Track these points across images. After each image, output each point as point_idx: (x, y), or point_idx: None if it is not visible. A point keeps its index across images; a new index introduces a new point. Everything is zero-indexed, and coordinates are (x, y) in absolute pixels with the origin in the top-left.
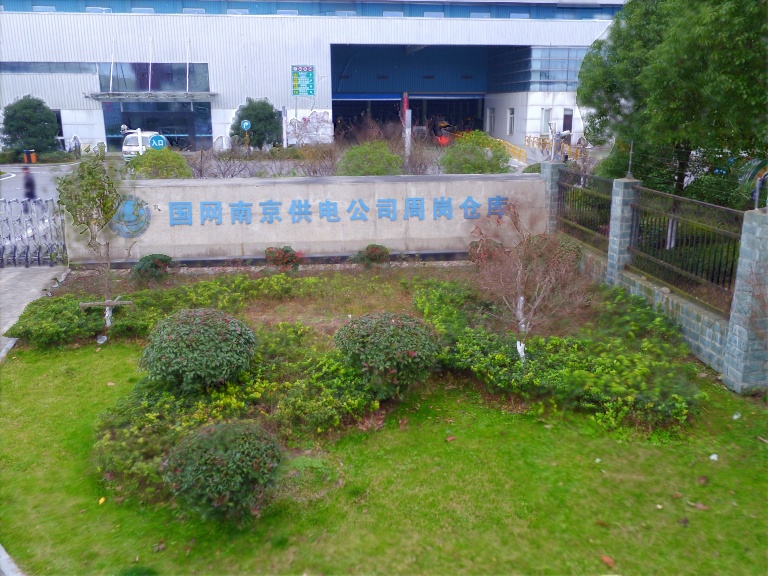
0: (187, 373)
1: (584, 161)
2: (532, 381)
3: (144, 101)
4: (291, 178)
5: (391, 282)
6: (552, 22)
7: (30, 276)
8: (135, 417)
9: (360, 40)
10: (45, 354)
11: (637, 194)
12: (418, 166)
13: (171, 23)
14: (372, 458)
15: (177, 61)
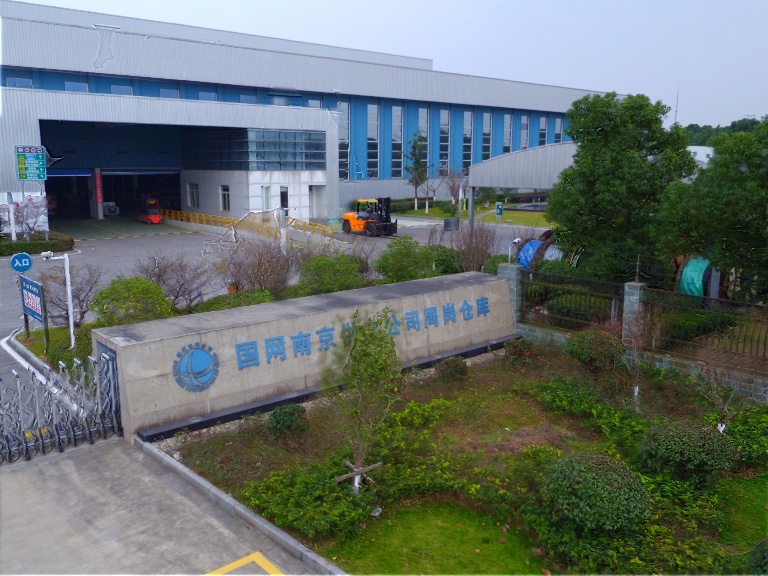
0: (644, 514)
1: None
2: (764, 451)
3: None
4: (305, 299)
5: None
6: (263, 107)
7: (97, 462)
8: (631, 567)
9: (74, 116)
10: (356, 544)
11: (650, 294)
12: None
13: None
14: (763, 538)
15: None
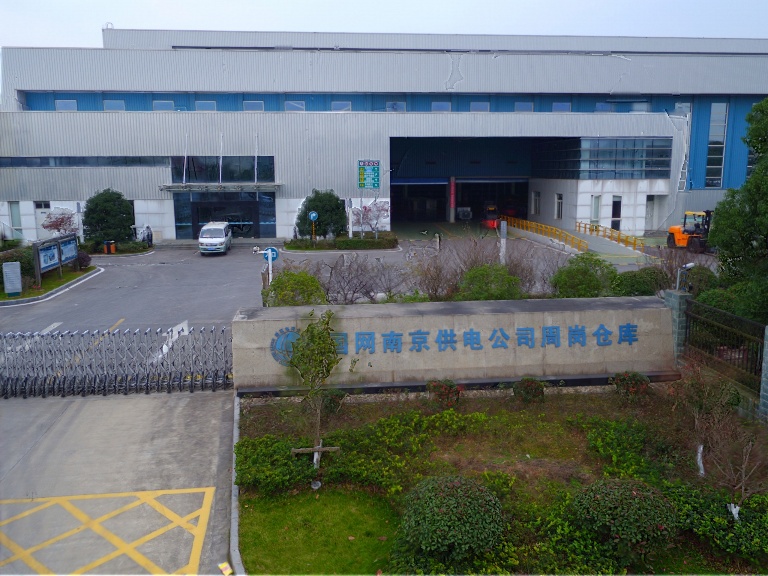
0: (463, 546)
1: (670, 268)
2: (762, 549)
3: (213, 191)
4: (428, 304)
5: (546, 414)
6: (600, 115)
7: (201, 404)
8: None
9: (418, 133)
10: (273, 502)
11: None
12: (527, 282)
13: (241, 120)
14: None
15: (245, 154)
